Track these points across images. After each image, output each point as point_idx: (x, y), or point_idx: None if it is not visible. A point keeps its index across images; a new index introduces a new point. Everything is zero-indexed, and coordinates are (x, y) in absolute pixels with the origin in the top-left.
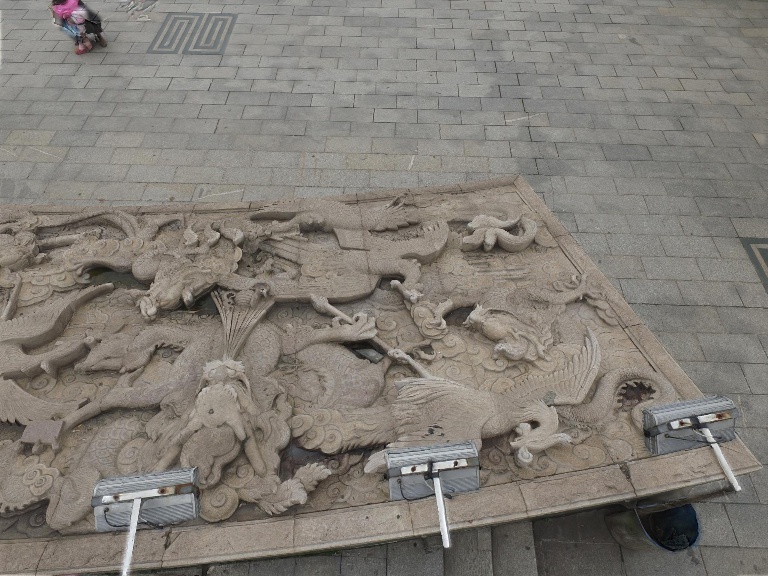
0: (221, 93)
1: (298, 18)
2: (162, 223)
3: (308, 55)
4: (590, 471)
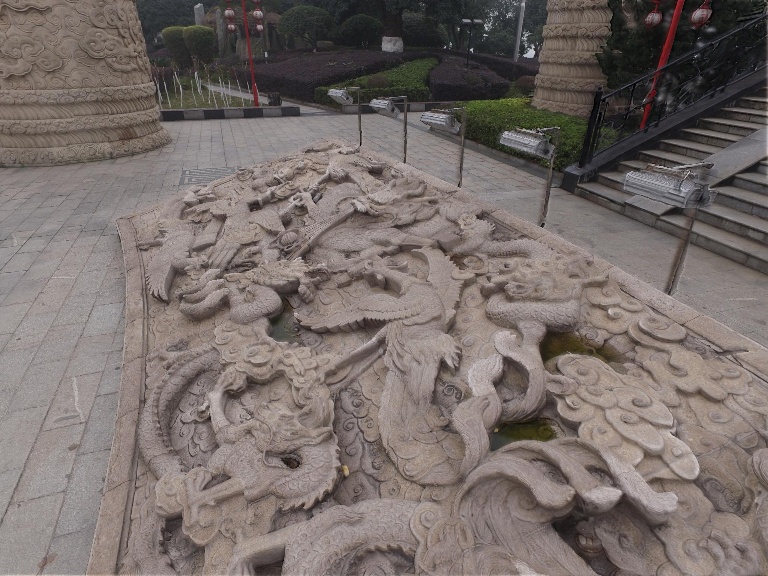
0: None
1: None
2: None
3: None
4: None
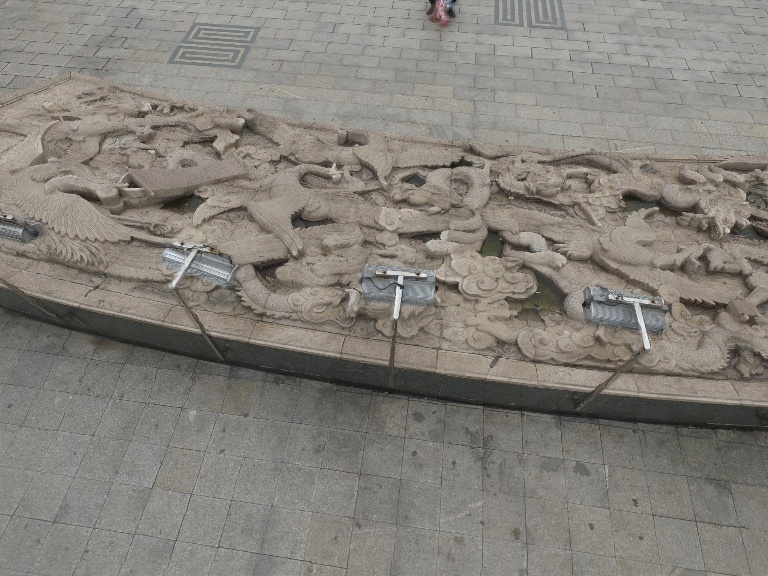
0: (584, 63)
1: (618, 1)
2: (640, 166)
3: (646, 34)
4: None
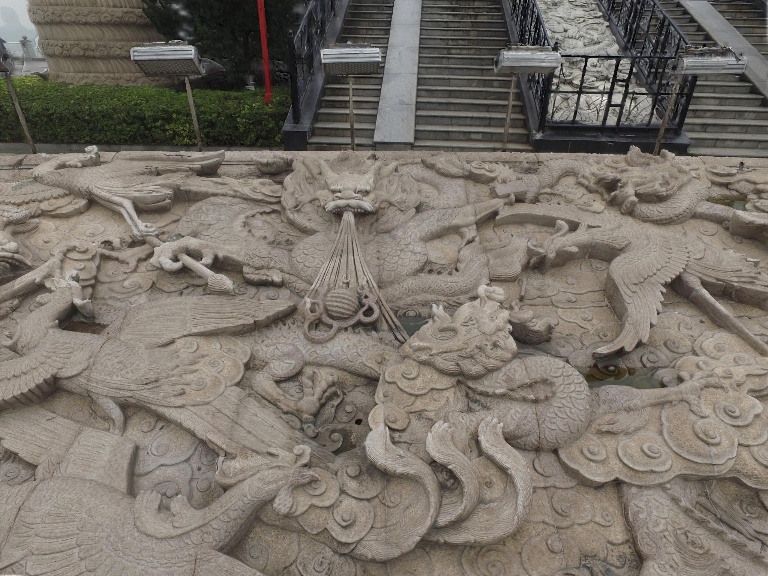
0: None
1: None
2: (645, 573)
3: None
4: None
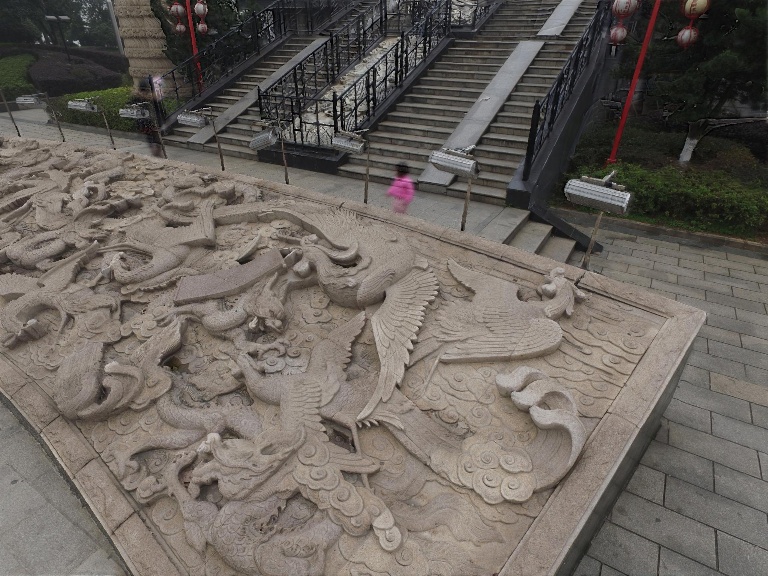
0: None
1: None
2: None
3: None
4: None
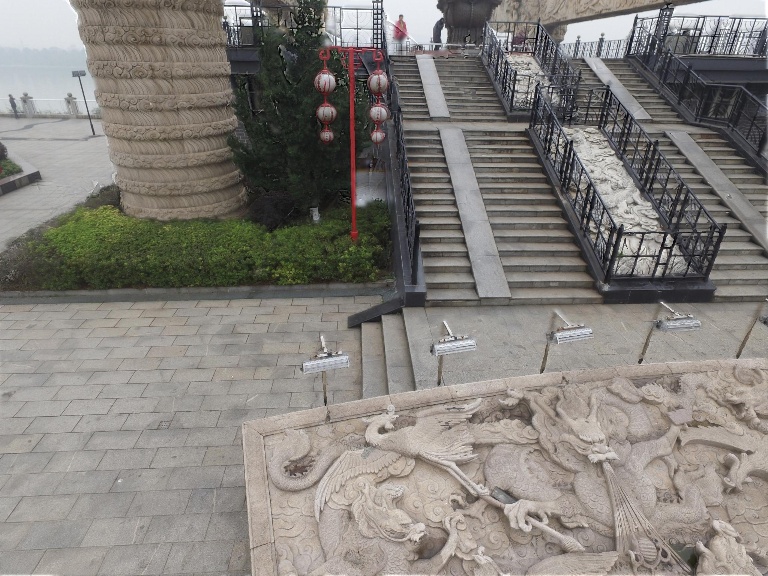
0: None
1: None
2: None
3: None
4: (349, 418)
